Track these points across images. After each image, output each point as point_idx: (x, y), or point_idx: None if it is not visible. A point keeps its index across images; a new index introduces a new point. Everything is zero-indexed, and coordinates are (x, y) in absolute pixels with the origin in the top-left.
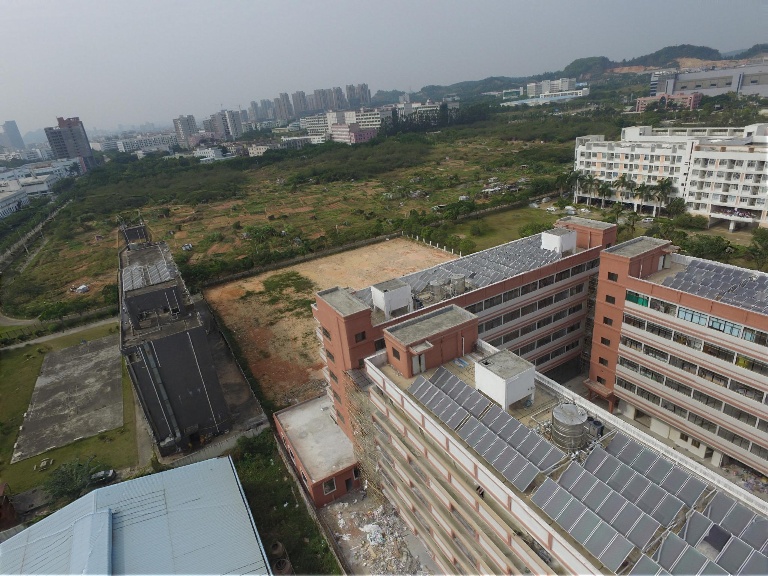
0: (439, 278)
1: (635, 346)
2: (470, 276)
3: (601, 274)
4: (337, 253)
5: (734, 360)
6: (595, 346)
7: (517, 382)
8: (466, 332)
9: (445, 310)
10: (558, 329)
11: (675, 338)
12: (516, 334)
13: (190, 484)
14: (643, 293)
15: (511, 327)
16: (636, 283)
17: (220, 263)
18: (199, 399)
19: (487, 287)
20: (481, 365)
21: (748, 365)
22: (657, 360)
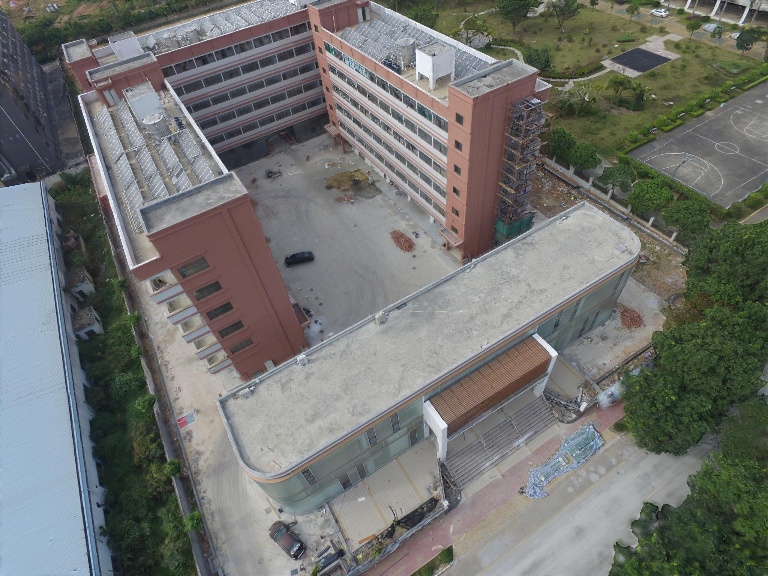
0: (183, 32)
1: (339, 92)
2: (211, 30)
3: (312, 26)
4: (202, 14)
5: (367, 96)
6: (325, 94)
7: (141, 102)
8: (150, 73)
9: (143, 56)
10: (308, 81)
11: (348, 82)
12: (261, 84)
13: (6, 197)
14: (329, 43)
15: (253, 78)
16: (325, 34)
17: (73, 25)
18: (21, 144)
19: (212, 39)
20: (123, 92)
21: (372, 99)
22: (346, 102)
